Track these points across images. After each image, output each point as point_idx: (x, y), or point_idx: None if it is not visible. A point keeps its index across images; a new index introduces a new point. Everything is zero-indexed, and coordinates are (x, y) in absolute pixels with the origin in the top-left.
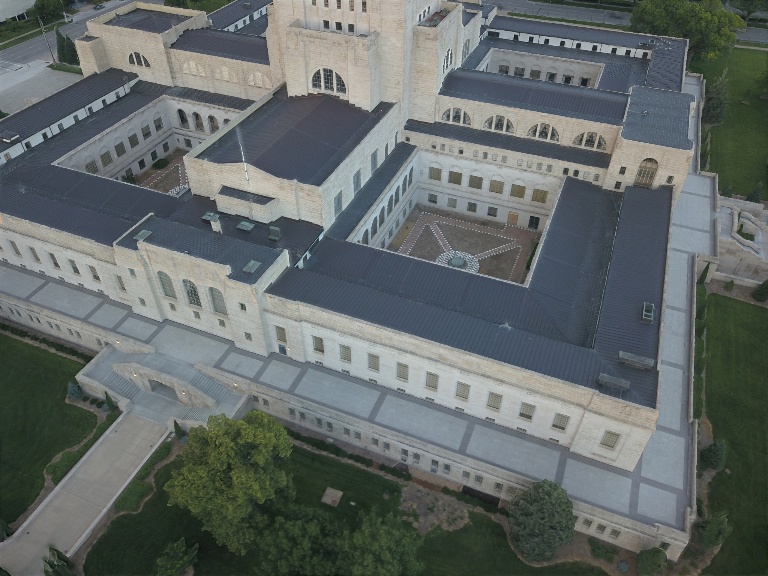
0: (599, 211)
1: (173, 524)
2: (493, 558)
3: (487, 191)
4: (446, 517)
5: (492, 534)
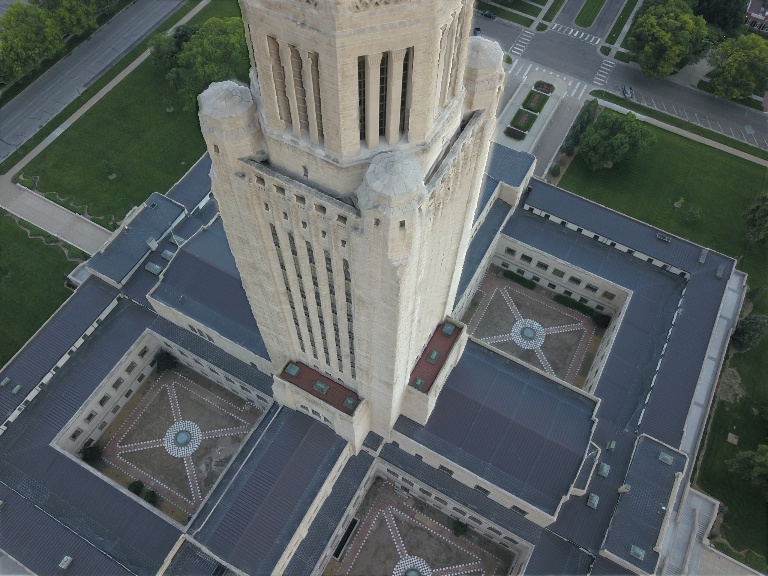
0: (539, 227)
1: (767, 533)
2: (751, 362)
3: (472, 291)
4: (734, 380)
5: (740, 359)
